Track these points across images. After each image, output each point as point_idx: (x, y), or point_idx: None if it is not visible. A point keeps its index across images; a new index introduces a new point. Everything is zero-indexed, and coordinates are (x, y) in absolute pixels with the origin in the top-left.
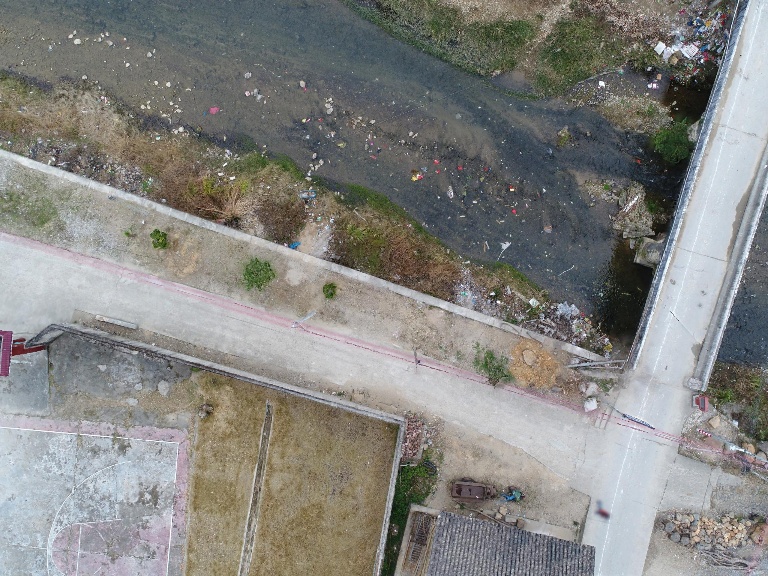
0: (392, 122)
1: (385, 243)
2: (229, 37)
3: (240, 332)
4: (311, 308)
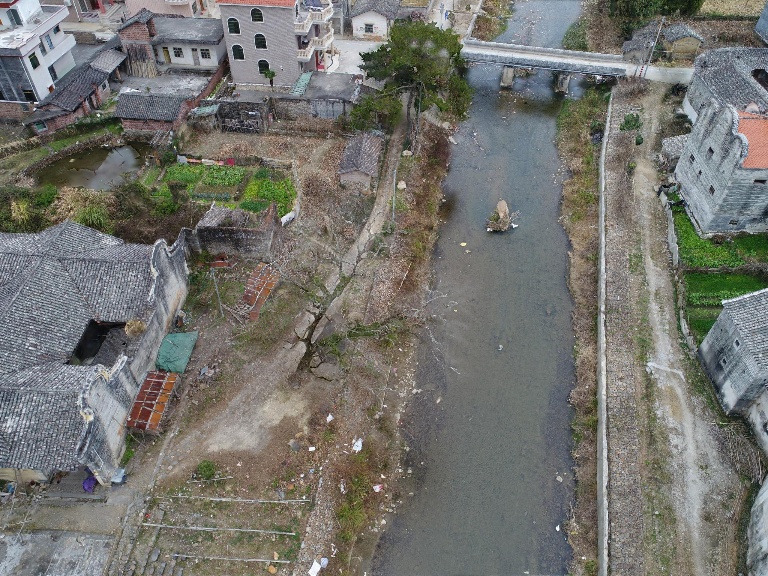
0: None
1: None
2: None
3: None
4: None
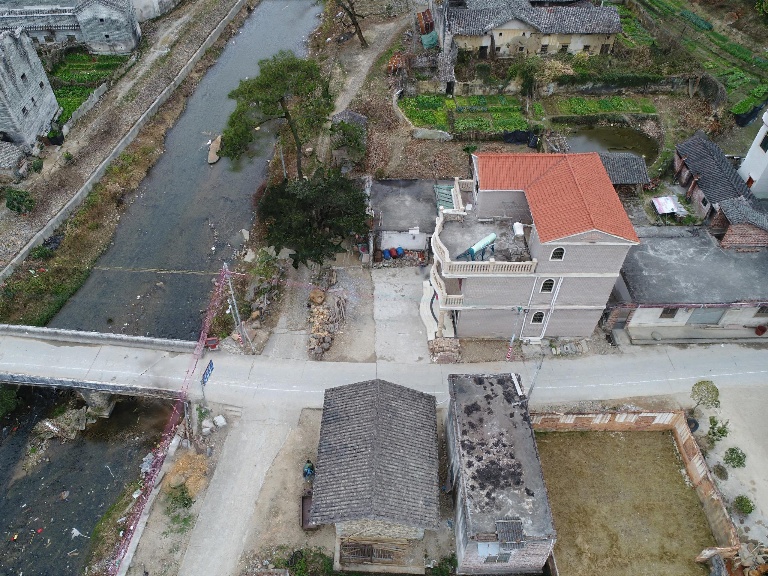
0: None
1: None
2: None
3: None
4: None
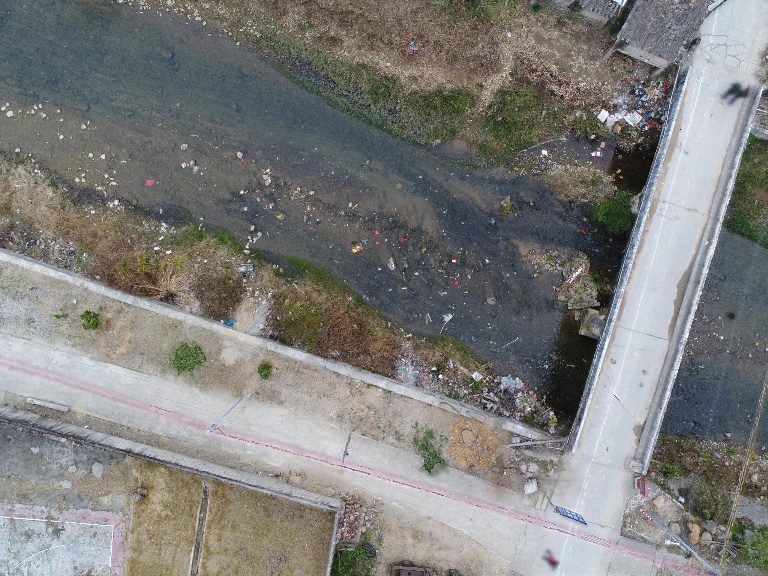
0: (331, 193)
1: (324, 318)
2: (165, 107)
3: (174, 413)
4: (246, 388)
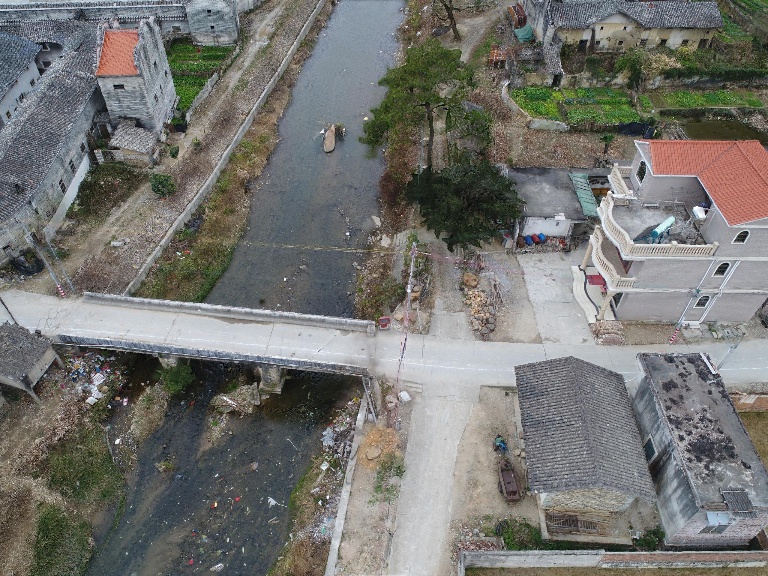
0: None
1: None
2: None
3: None
4: None
